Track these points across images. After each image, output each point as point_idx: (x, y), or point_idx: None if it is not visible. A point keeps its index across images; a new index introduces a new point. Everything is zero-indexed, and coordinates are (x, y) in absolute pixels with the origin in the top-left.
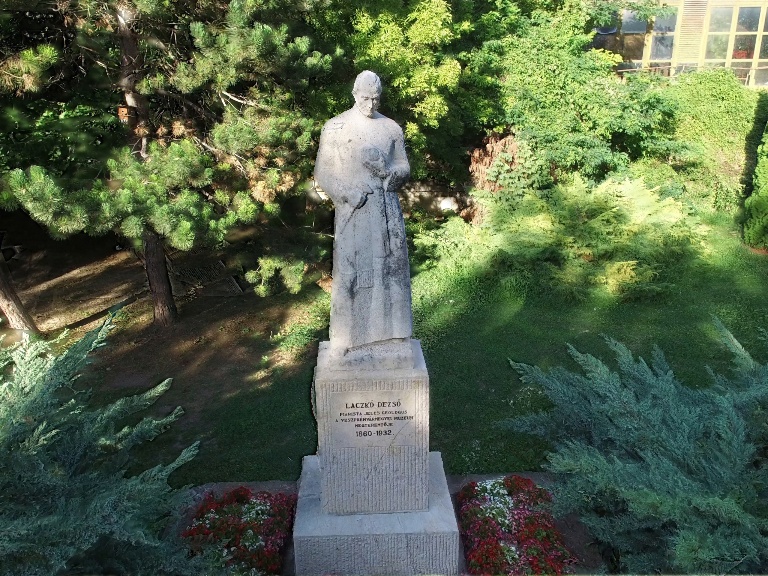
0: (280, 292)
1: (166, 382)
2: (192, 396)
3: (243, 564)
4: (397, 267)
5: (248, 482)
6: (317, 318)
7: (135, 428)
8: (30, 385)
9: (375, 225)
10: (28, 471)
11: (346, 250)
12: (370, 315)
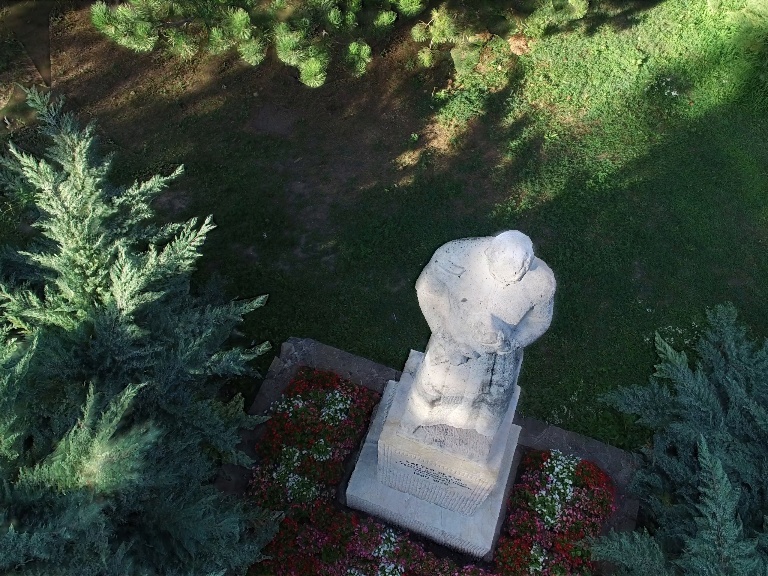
0: (451, 57)
1: (262, 298)
2: (327, 174)
3: (306, 480)
4: (493, 402)
5: (343, 352)
6: (498, 66)
7: (224, 354)
8: (126, 311)
9: (474, 375)
10: (92, 529)
11: (432, 380)
12: (452, 413)
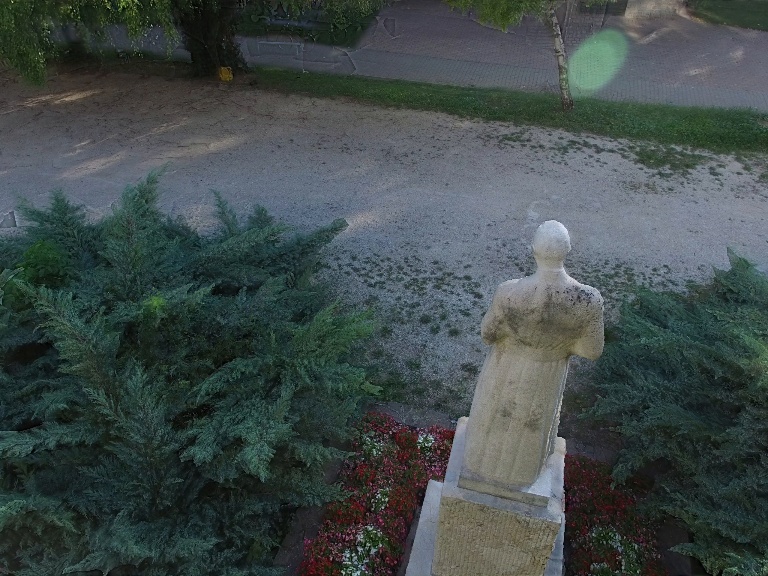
0: None
1: None
2: None
3: None
4: None
5: None
6: None
7: (757, 575)
8: None
9: None
10: None
11: None
12: None
